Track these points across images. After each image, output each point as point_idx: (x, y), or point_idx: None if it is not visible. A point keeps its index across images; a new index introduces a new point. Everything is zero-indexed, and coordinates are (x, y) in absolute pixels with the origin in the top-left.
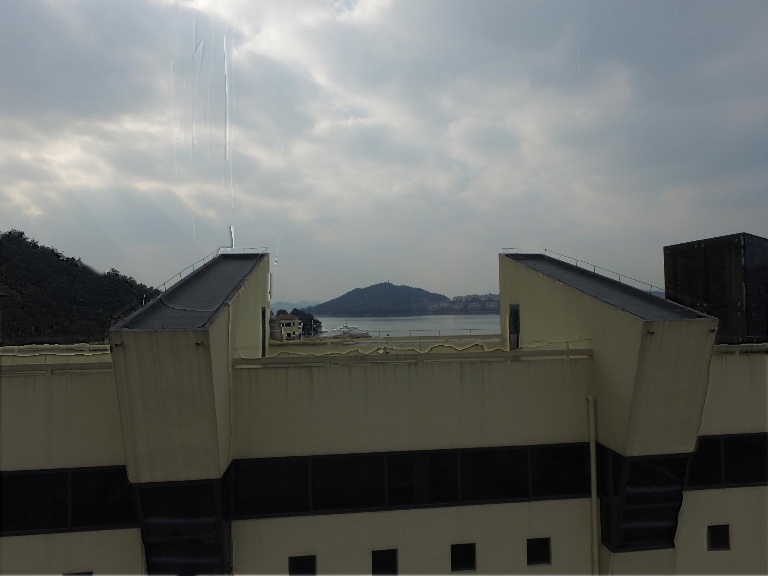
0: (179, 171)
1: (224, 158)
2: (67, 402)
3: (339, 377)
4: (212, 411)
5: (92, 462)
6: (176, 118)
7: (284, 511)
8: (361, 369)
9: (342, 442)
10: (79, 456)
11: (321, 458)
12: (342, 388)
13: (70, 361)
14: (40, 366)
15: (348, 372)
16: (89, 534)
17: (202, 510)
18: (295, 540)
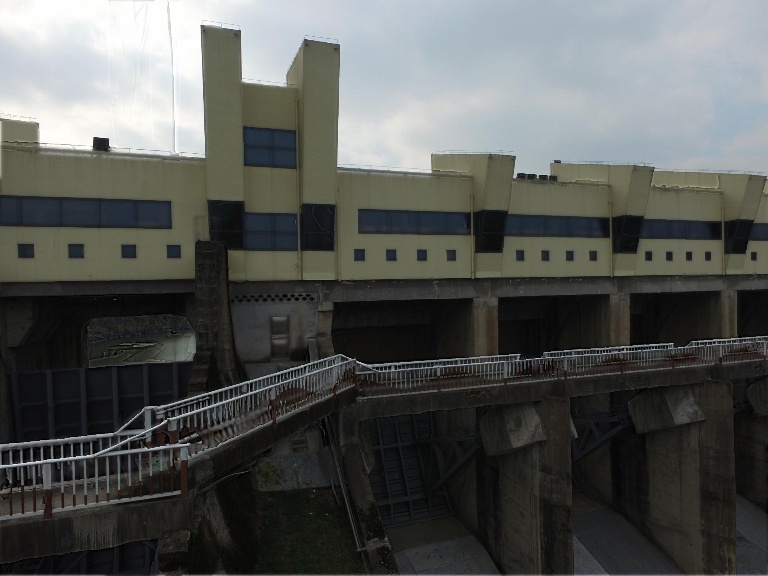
0: (118, 140)
1: (172, 129)
2: (704, 202)
3: (761, 200)
4: (760, 199)
5: (711, 220)
6: (115, 83)
7: (749, 239)
8: (766, 198)
9: (761, 220)
10: (707, 218)
11: (757, 224)
12: (761, 203)
13: (705, 190)
14: (699, 190)
15: (763, 199)
16: (710, 241)
17: (743, 232)
18: (752, 247)
